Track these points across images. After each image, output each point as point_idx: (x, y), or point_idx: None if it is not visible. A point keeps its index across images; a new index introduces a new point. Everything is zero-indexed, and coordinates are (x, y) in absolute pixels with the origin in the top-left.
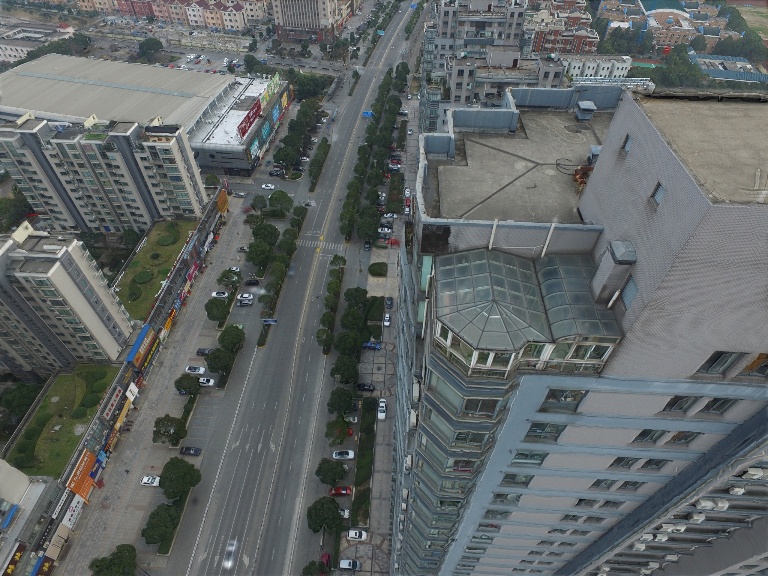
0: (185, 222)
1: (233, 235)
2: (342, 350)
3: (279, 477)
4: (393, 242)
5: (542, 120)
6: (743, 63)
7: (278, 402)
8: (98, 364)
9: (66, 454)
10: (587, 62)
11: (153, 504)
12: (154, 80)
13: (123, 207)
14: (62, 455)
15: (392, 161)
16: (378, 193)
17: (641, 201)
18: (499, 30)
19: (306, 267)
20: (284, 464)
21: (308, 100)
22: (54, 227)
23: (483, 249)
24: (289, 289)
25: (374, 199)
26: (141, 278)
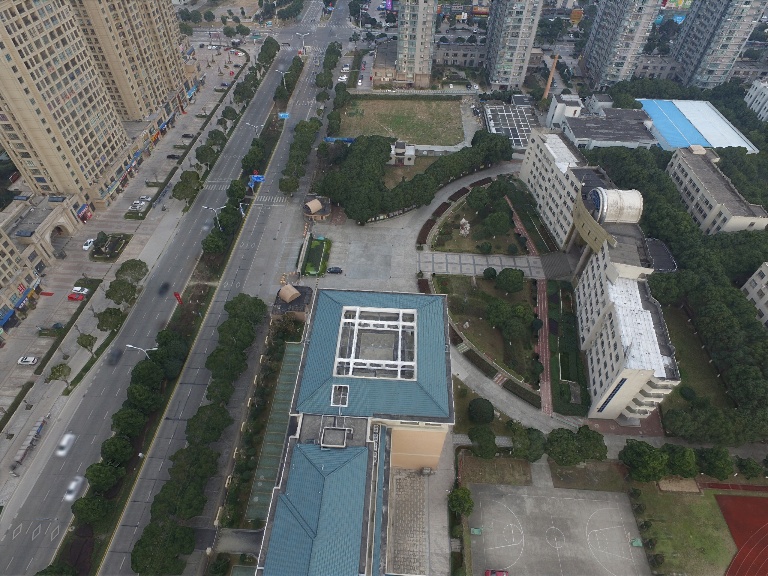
0: (552, 7)
1: None
2: None
3: None
4: None
5: None
6: None
7: None
8: None
9: None
10: None
11: None
12: None
13: None
14: None
15: None
16: None
17: None
18: None
19: None
20: None
21: None
22: None
23: None
24: None
25: None
26: None
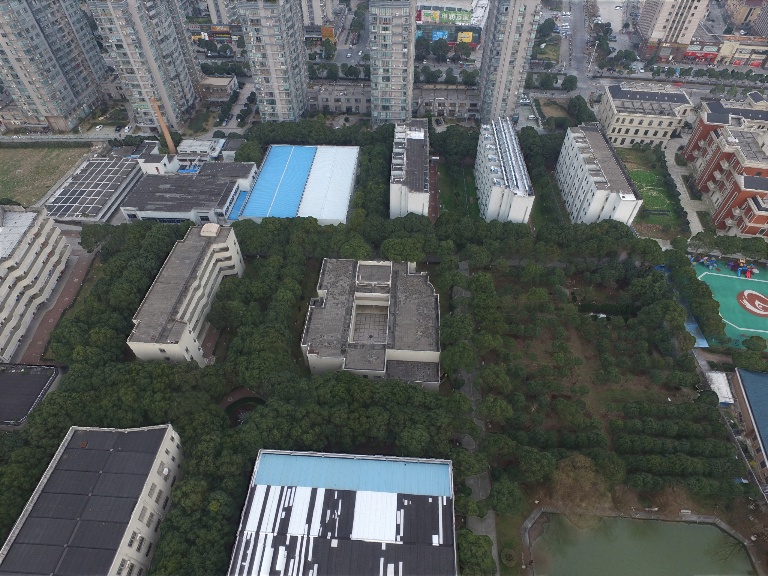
0: None
1: None
2: None
3: None
4: None
5: None
6: None
7: None
8: None
9: None
10: None
11: None
12: None
13: None
14: None
15: None
16: None
17: None
18: None
19: None
20: None
21: None
22: None
23: None
24: None
25: None
26: None
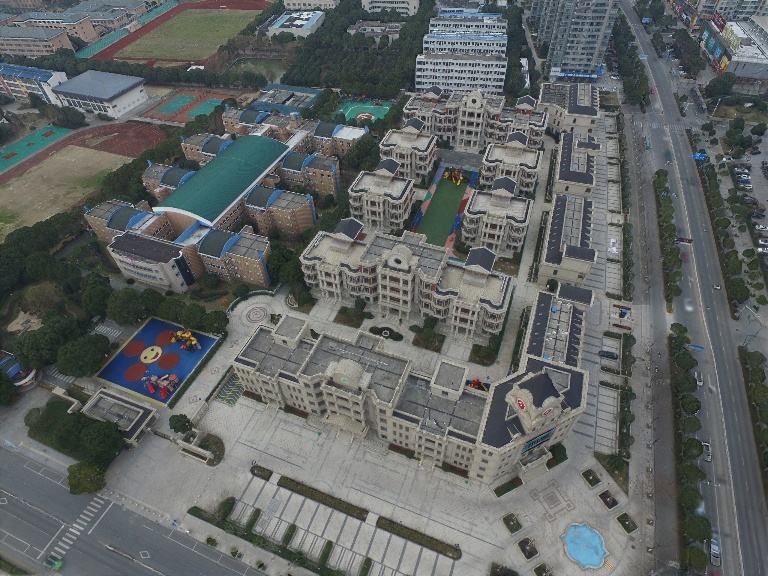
0: None
1: None
2: None
3: None
4: None
5: None
6: None
7: None
8: None
9: None
10: None
11: None
12: None
13: None
14: None
15: None
16: None
17: None
18: None
19: None
20: None
21: None
22: None
23: None
24: None
25: None
26: None
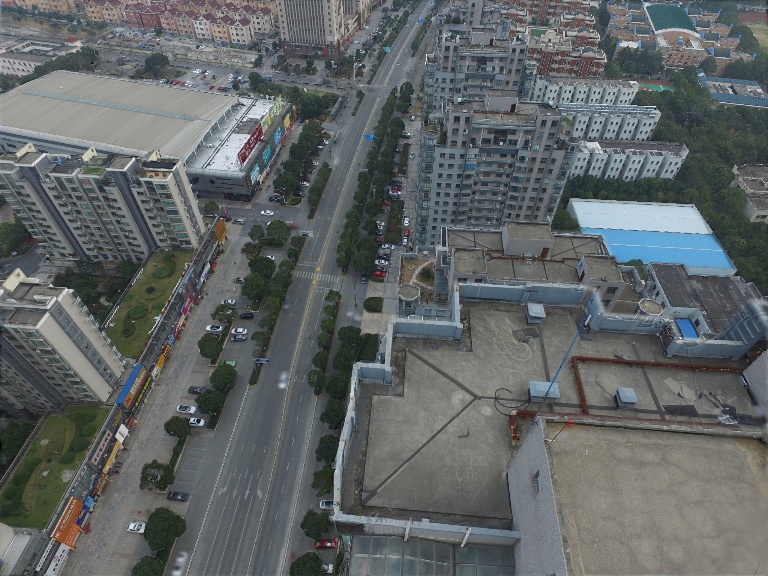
0: (182, 253)
1: (230, 264)
2: (333, 393)
3: (265, 526)
4: (390, 275)
5: (491, 320)
6: (753, 87)
7: (267, 445)
8: (89, 405)
9: (53, 502)
10: (593, 87)
11: (138, 552)
12: (157, 101)
13: (121, 237)
14: (49, 503)
15: (392, 188)
16: (377, 223)
17: (543, 569)
18: (500, 65)
19: (301, 300)
20: (270, 513)
21: (310, 122)
22: (53, 254)
23: (400, 537)
24: (283, 323)
25: (372, 230)
26: (135, 313)
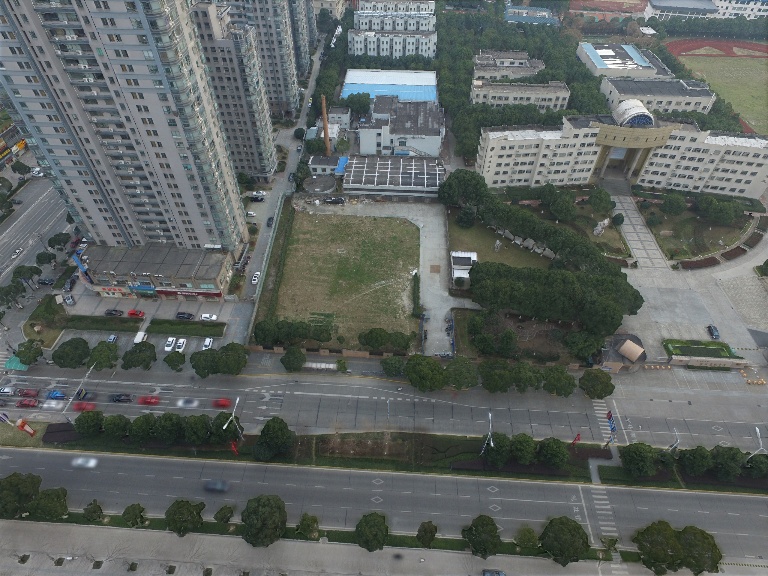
0: None
1: None
2: None
3: (66, 212)
4: None
5: None
6: (544, 12)
7: None
8: None
9: None
10: None
11: None
12: None
13: None
14: None
15: None
16: None
17: None
18: None
19: None
20: None
21: None
22: None
23: None
24: None
25: None
26: (4, 116)
